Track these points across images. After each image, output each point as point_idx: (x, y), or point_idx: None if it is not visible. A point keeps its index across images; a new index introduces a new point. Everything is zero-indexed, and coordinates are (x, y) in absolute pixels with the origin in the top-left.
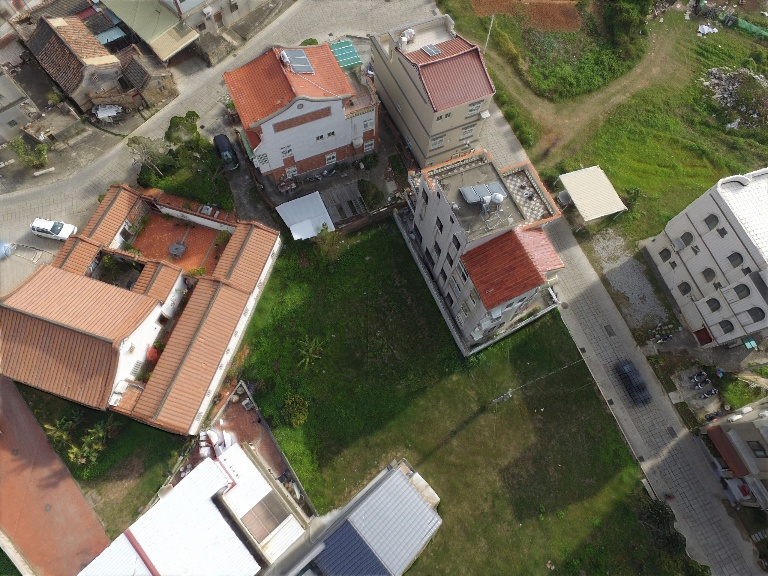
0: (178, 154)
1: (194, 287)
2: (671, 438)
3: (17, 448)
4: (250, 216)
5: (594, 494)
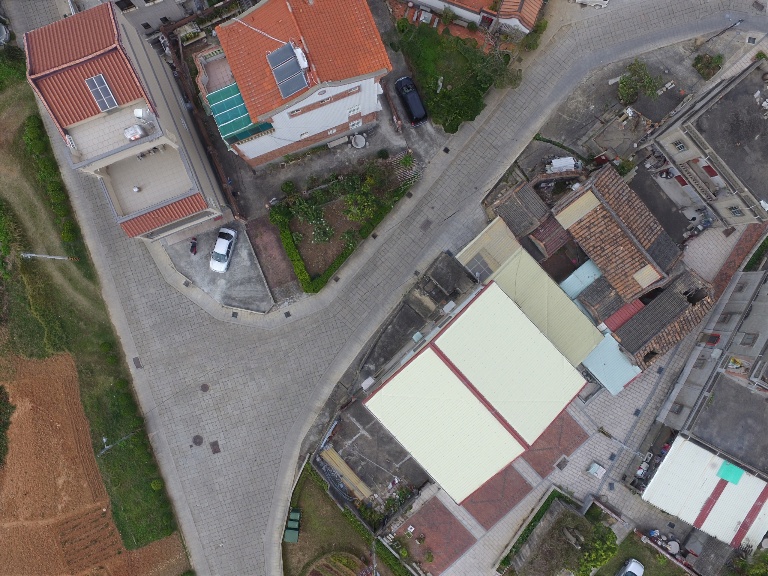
0: None
1: None
2: None
3: None
4: (378, 18)
5: None
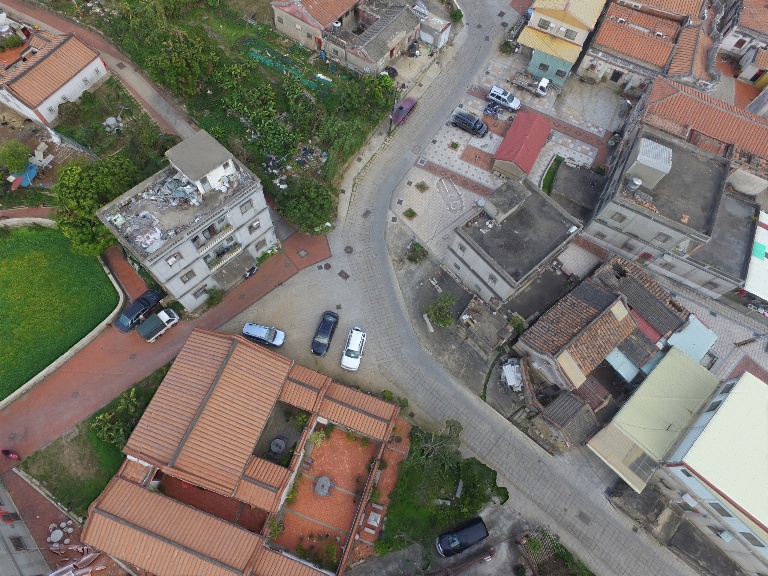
0: (458, 469)
1: None
2: None
3: (136, 357)
4: None
5: None
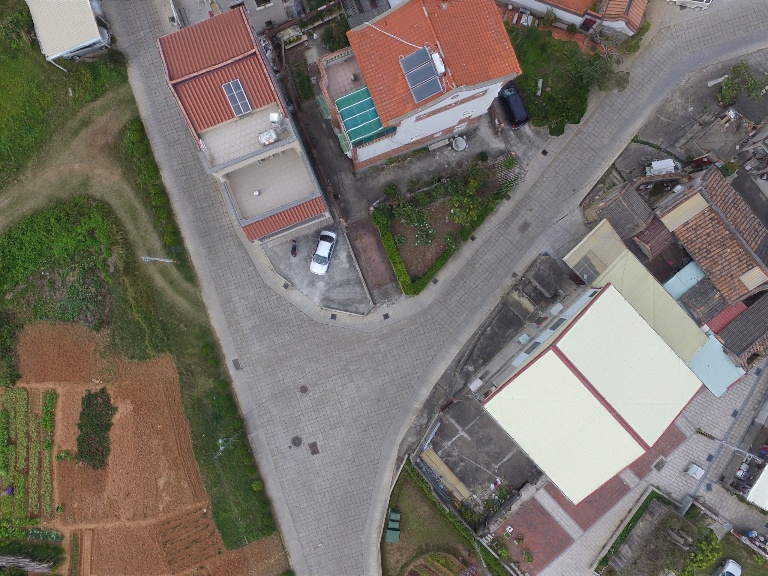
0: None
1: None
2: None
3: None
4: None
5: None
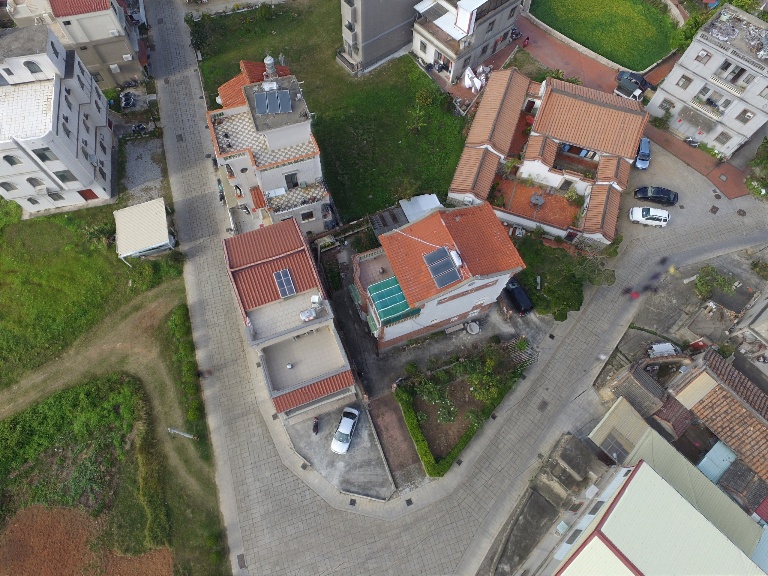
0: None
1: (514, 171)
2: (169, 79)
3: (600, 88)
4: None
5: (235, 57)
